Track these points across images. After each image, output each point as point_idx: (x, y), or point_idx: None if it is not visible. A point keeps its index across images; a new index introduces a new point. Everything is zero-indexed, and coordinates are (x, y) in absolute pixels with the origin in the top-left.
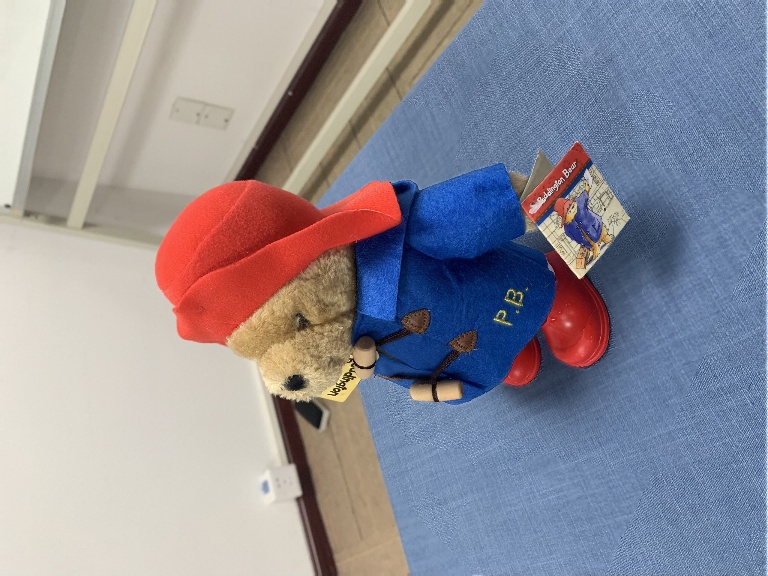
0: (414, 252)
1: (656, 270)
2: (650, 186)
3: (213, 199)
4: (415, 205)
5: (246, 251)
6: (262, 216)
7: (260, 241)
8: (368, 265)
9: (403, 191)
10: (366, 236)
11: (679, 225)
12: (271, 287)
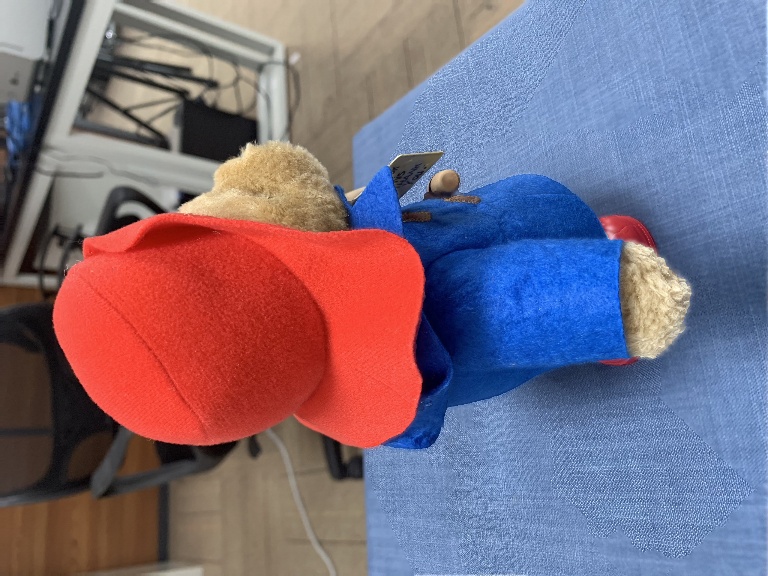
0: None
1: None
2: None
3: None
4: None
5: None
6: None
7: None
8: None
9: None
10: None
11: None
12: None
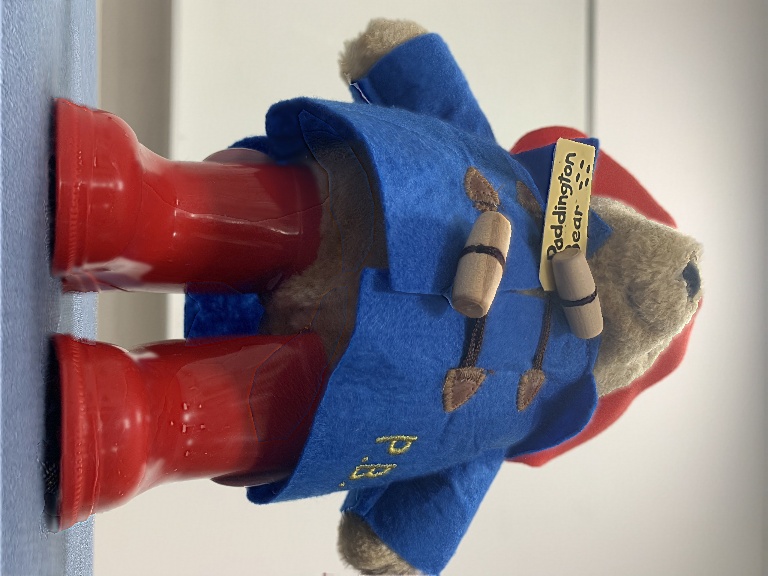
0: None
1: None
2: None
3: None
4: None
5: None
6: None
7: None
8: None
9: None
10: None
11: None
12: None
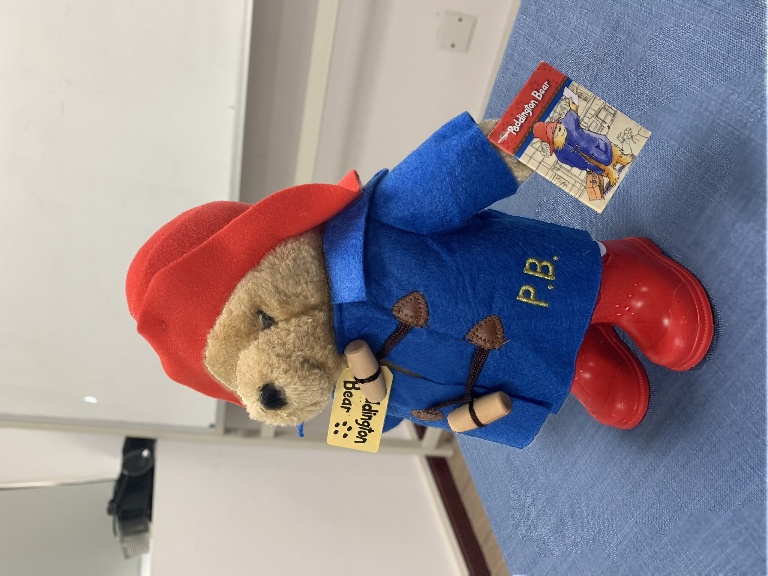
0: (387, 228)
1: (737, 204)
2: (697, 117)
3: None
4: (381, 181)
5: None
6: (213, 218)
7: None
8: (333, 248)
9: None
10: (323, 216)
11: (743, 139)
12: (224, 284)
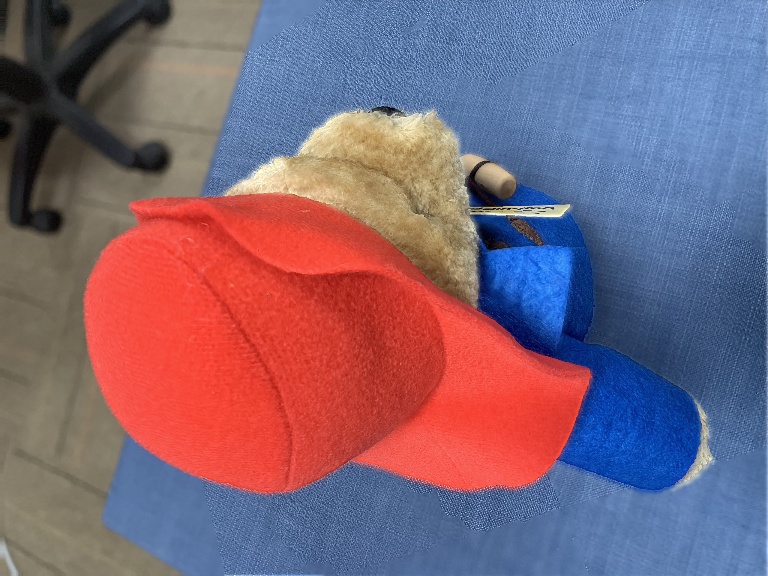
0: None
1: None
2: None
3: None
4: None
5: None
6: None
7: None
8: None
9: None
10: None
11: None
12: None
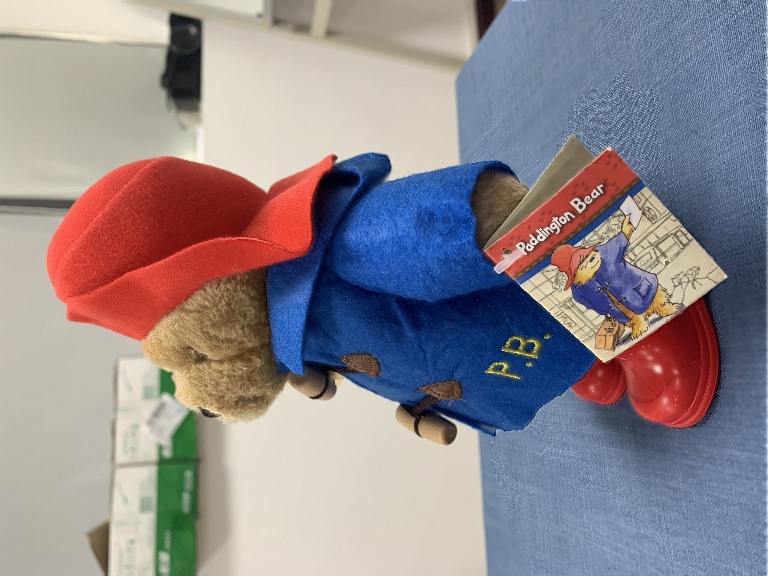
0: (343, 285)
1: None
2: None
3: (90, 195)
4: (346, 219)
5: (112, 273)
6: (131, 229)
7: (128, 262)
8: (274, 298)
9: (353, 184)
10: None
11: None
12: (149, 316)
